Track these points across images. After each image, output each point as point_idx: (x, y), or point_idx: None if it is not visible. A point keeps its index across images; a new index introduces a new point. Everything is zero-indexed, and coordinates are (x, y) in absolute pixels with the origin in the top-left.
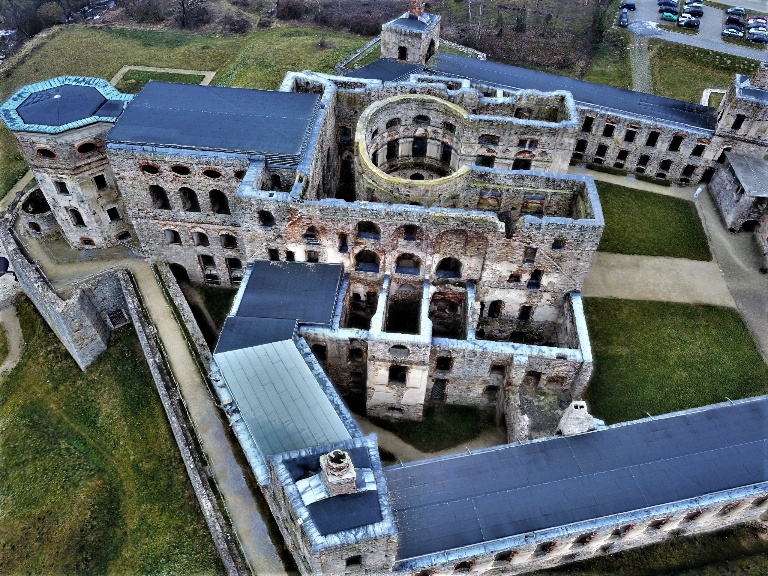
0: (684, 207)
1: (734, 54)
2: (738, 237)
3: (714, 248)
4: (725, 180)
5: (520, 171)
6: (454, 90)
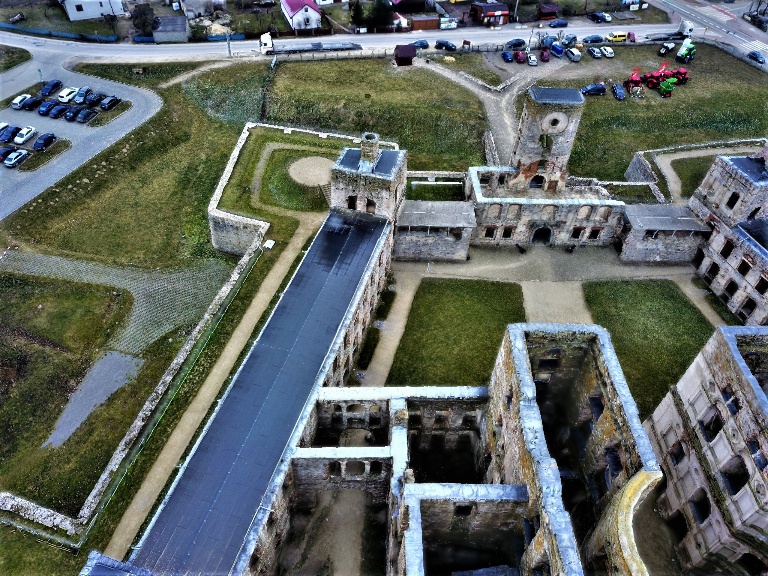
0: (435, 287)
1: (70, 171)
2: (476, 257)
3: (499, 278)
4: (420, 240)
5: (764, 403)
6: (546, 499)
